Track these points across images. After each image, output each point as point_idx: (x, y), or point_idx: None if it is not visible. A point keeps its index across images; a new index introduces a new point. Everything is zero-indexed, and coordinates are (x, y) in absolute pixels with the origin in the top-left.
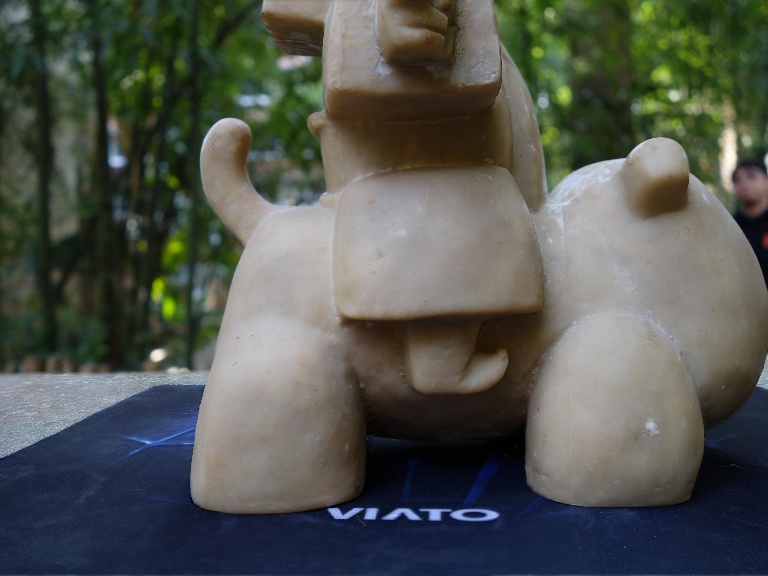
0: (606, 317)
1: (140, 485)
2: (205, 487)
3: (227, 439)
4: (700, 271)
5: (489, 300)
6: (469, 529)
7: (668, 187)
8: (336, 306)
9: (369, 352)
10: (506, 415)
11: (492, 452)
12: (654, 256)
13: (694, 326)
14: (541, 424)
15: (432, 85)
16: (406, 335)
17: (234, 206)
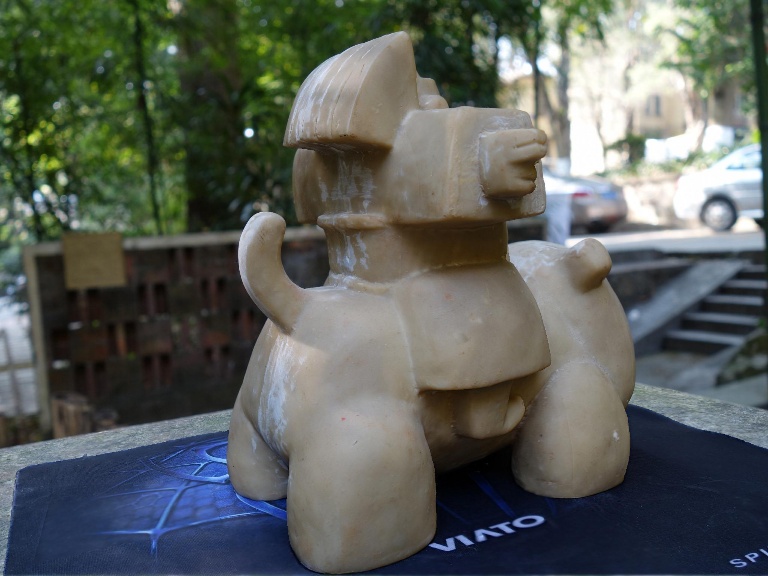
0: (577, 365)
1: (234, 572)
2: (342, 555)
3: (362, 508)
4: (615, 327)
5: (533, 365)
6: (542, 532)
7: (602, 273)
8: (417, 380)
9: (433, 413)
10: (500, 442)
11: (467, 471)
12: (592, 319)
13: (615, 363)
14: (547, 446)
15: (510, 213)
16: (467, 396)
17: (280, 294)
